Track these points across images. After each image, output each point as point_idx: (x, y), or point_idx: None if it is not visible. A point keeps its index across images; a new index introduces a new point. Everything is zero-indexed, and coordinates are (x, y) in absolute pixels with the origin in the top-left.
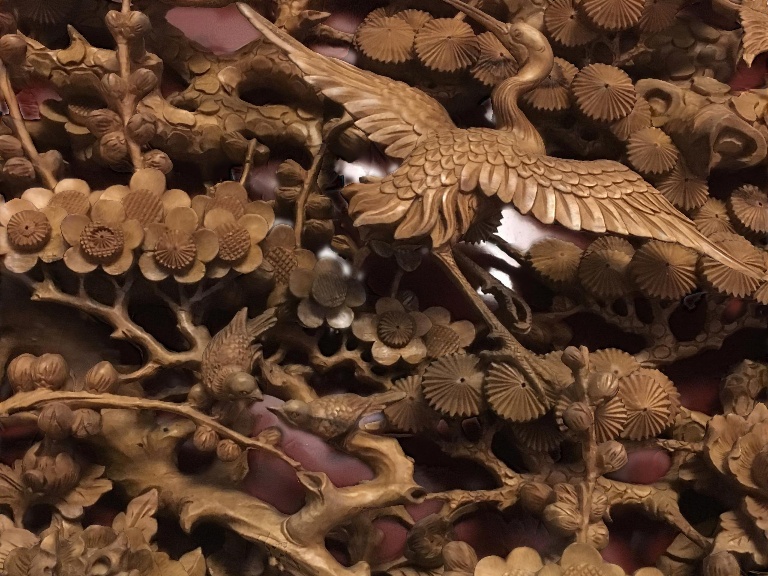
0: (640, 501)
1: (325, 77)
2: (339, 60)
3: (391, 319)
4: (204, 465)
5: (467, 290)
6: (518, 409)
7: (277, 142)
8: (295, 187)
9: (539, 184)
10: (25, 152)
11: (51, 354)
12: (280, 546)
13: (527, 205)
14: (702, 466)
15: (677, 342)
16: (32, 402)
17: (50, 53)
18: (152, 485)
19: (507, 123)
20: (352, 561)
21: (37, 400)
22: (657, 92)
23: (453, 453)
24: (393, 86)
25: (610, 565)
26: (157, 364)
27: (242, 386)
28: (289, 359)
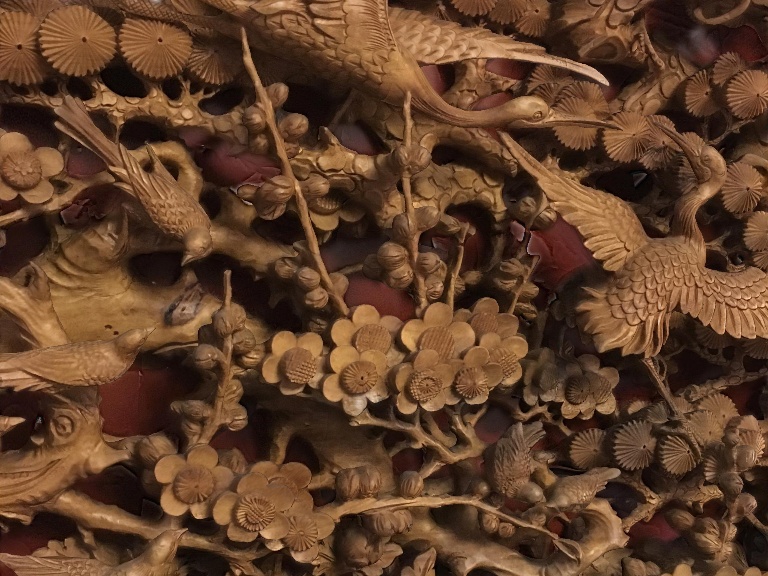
0: (720, 497)
1: (565, 203)
2: (570, 180)
3: (578, 386)
4: (451, 515)
5: (661, 387)
6: (682, 468)
7: (464, 205)
8: (514, 280)
9: (717, 301)
10: (321, 282)
11: (372, 470)
12: None
13: (708, 319)
14: (761, 472)
15: (746, 373)
16: (362, 511)
17: (310, 158)
18: (420, 539)
19: (686, 234)
20: (535, 557)
21: (367, 509)
22: (760, 169)
23: (611, 480)
24: (610, 204)
25: None
26: (444, 463)
27: (538, 499)
28: (491, 412)
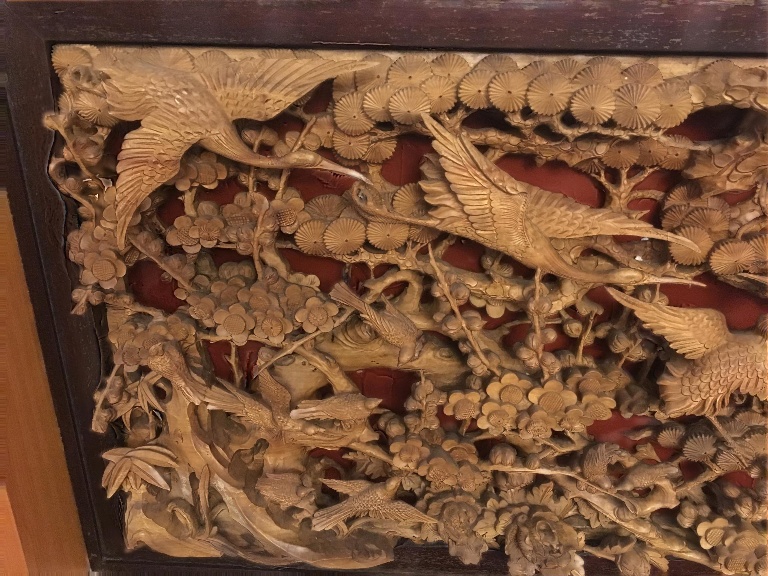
0: None
1: (655, 323)
2: (664, 306)
3: None
4: (569, 462)
5: (719, 429)
6: (732, 469)
7: None
8: None
9: None
10: None
11: (509, 453)
12: (614, 520)
13: (765, 397)
14: None
15: None
16: None
17: (481, 289)
18: None
19: (764, 336)
20: None
21: None
22: None
23: None
24: (696, 320)
25: (761, 537)
26: None
27: None
28: None
